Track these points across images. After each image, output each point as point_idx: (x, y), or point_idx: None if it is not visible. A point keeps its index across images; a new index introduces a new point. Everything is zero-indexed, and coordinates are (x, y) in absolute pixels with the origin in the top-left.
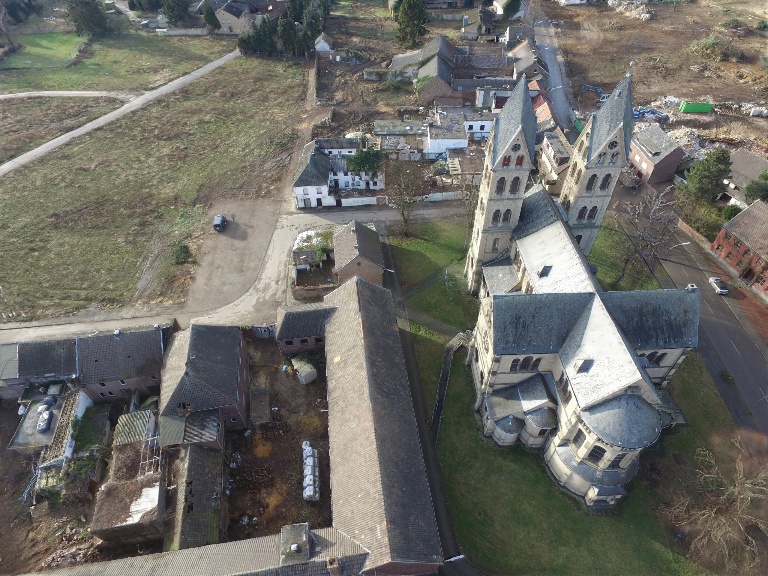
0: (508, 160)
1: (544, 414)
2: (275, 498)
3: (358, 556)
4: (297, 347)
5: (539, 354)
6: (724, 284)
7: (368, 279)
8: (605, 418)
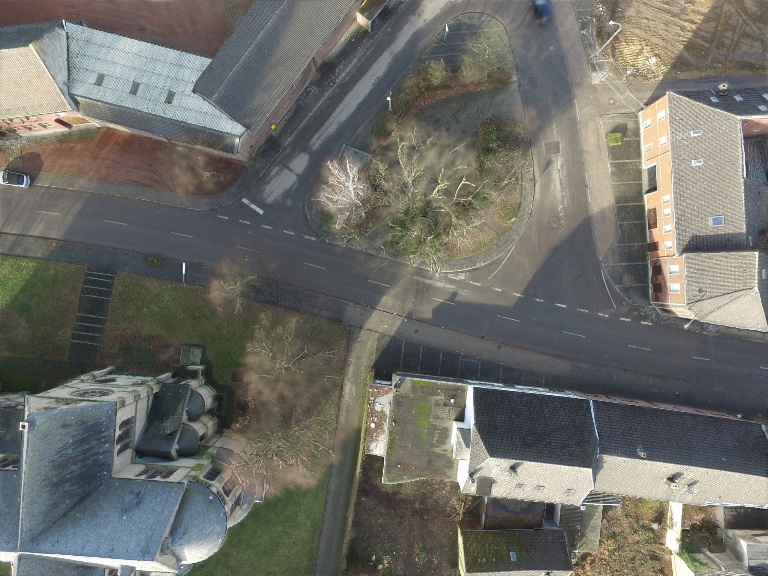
0: None
1: None
2: None
3: None
4: None
5: None
6: (13, 176)
7: None
8: (192, 555)
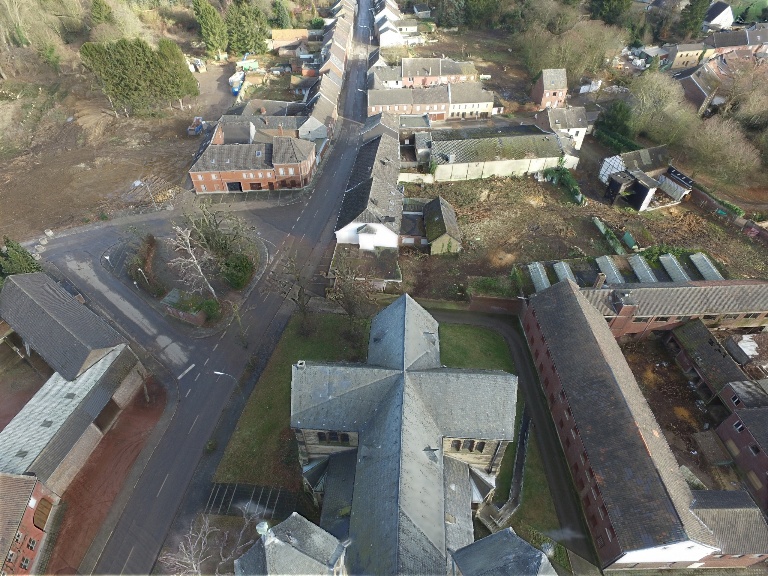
0: None
1: None
2: (650, 376)
3: None
4: None
5: None
6: None
7: None
8: None
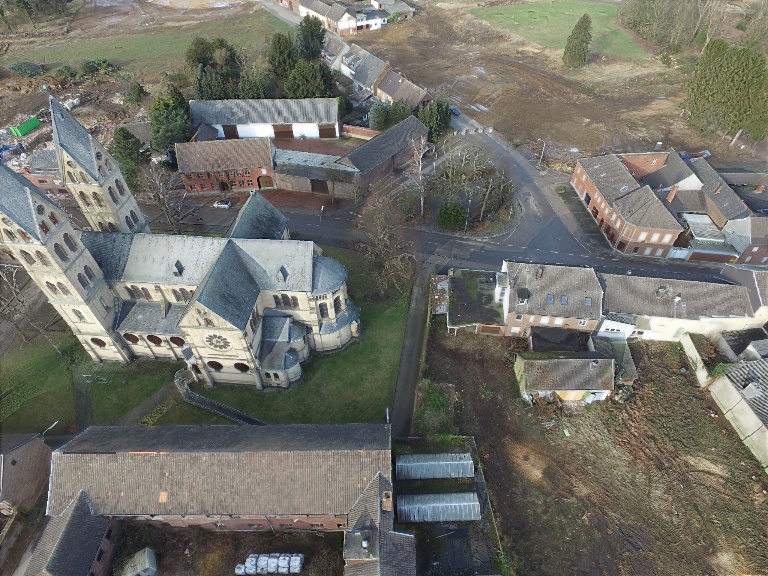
0: (44, 226)
1: (295, 328)
2: None
3: (380, 483)
4: (100, 571)
5: (255, 302)
6: (224, 201)
7: (37, 465)
8: (323, 281)
